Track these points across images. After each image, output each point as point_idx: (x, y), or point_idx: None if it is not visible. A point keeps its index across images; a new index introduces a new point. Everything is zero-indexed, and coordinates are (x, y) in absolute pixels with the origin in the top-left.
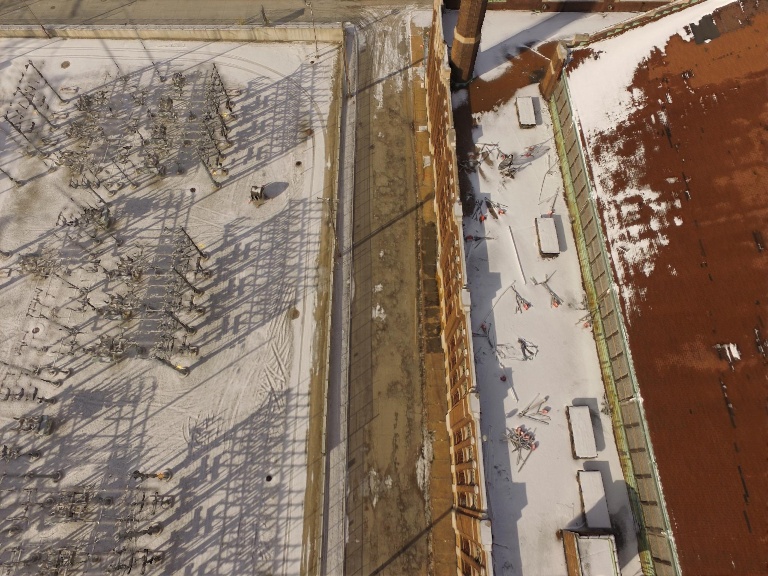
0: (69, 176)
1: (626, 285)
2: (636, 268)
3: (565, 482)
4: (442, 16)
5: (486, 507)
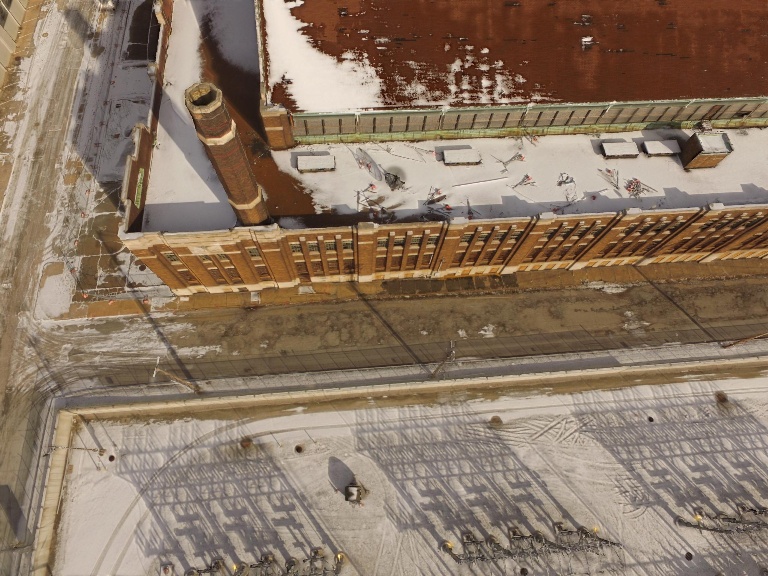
0: None
1: (531, 97)
2: (519, 87)
3: (654, 164)
4: None
5: (698, 208)
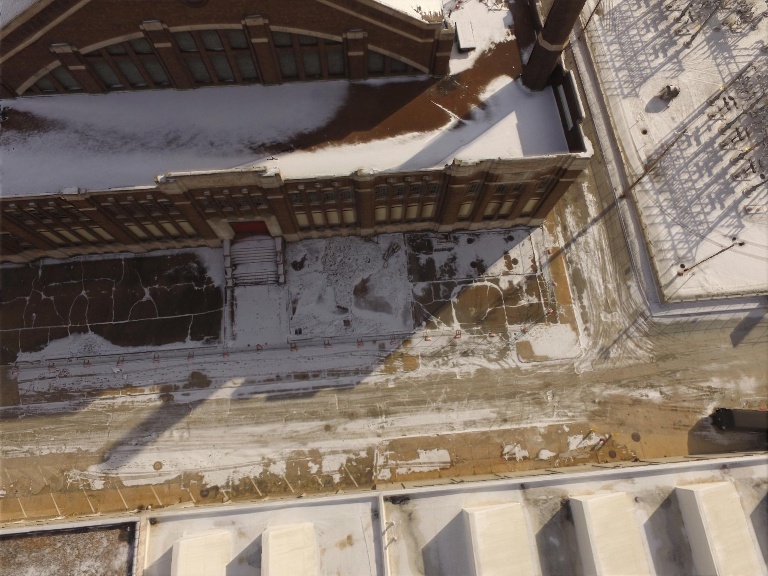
0: None
1: None
2: None
3: None
4: (571, 143)
5: None
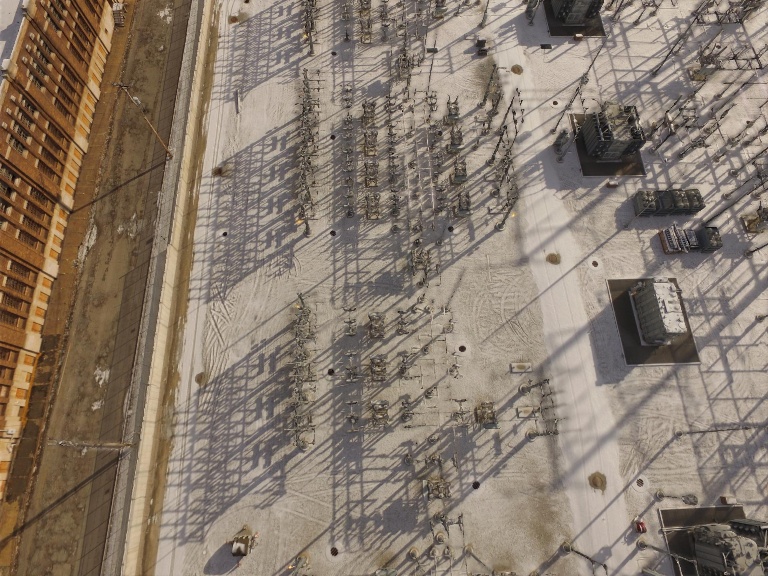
0: (507, 567)
1: None
2: None
3: None
4: None
5: None
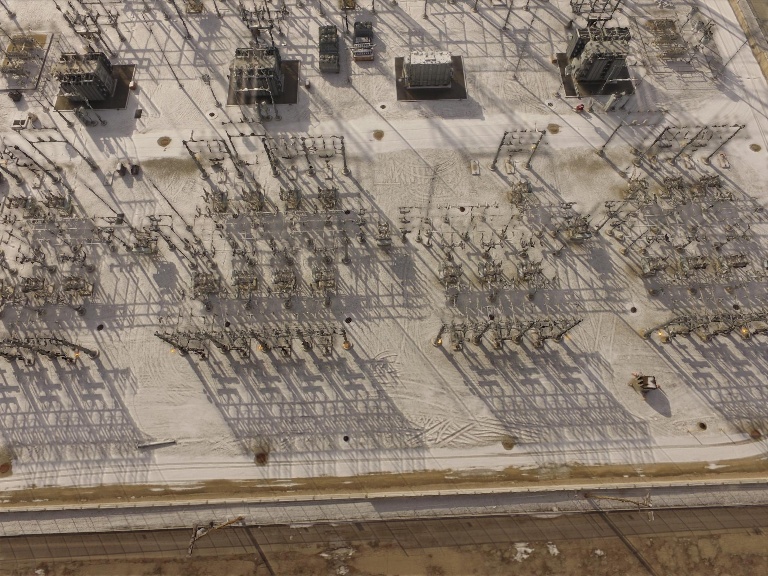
0: (620, 190)
1: None
2: None
3: None
4: None
5: None
